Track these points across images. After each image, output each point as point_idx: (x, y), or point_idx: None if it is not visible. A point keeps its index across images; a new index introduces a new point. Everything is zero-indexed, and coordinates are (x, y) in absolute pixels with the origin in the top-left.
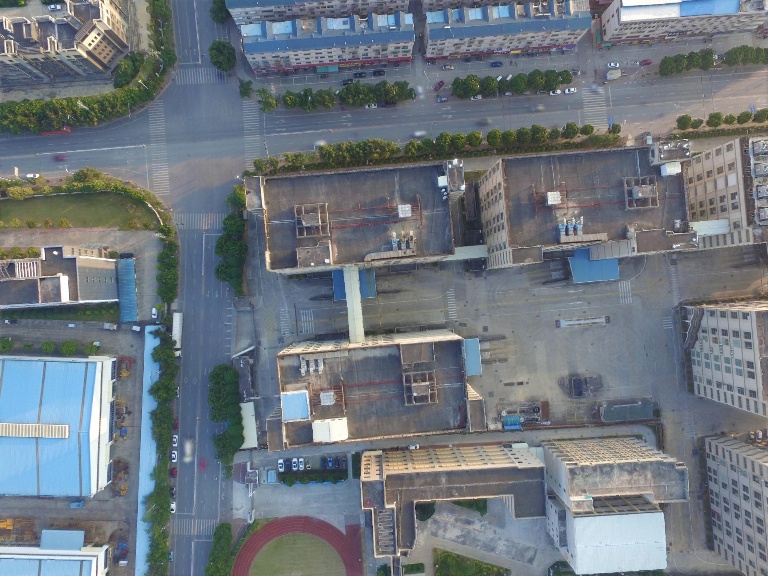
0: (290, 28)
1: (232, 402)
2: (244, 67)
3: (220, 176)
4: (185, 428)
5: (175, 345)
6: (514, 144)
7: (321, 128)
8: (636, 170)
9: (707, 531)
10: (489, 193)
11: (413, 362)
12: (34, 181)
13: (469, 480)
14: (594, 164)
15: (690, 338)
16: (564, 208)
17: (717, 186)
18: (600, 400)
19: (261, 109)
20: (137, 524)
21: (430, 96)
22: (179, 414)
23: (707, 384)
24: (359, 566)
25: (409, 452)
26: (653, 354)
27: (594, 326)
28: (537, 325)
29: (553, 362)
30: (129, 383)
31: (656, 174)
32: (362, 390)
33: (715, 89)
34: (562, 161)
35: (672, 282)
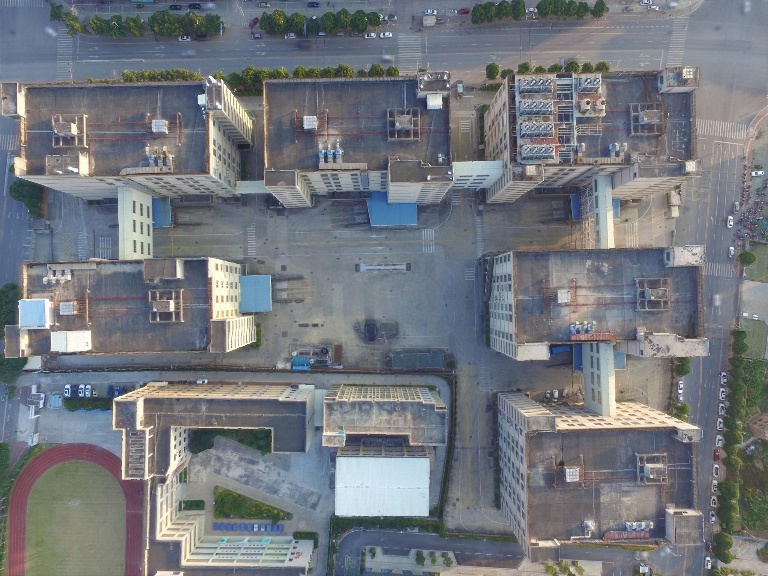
0: None
1: (14, 320)
2: None
3: None
4: None
5: None
6: None
7: (133, 57)
8: (402, 102)
9: (496, 489)
10: None
11: (155, 277)
12: None
13: (230, 410)
14: (360, 93)
15: (487, 289)
16: (325, 135)
17: (500, 129)
18: (395, 348)
19: (68, 33)
20: None
21: (245, 32)
22: None
23: (495, 335)
24: (140, 499)
25: (195, 386)
26: (453, 305)
27: (394, 272)
28: (336, 268)
29: (350, 306)
30: None
31: (422, 107)
32: (109, 304)
33: (533, 42)
34: (328, 88)
35: (477, 233)
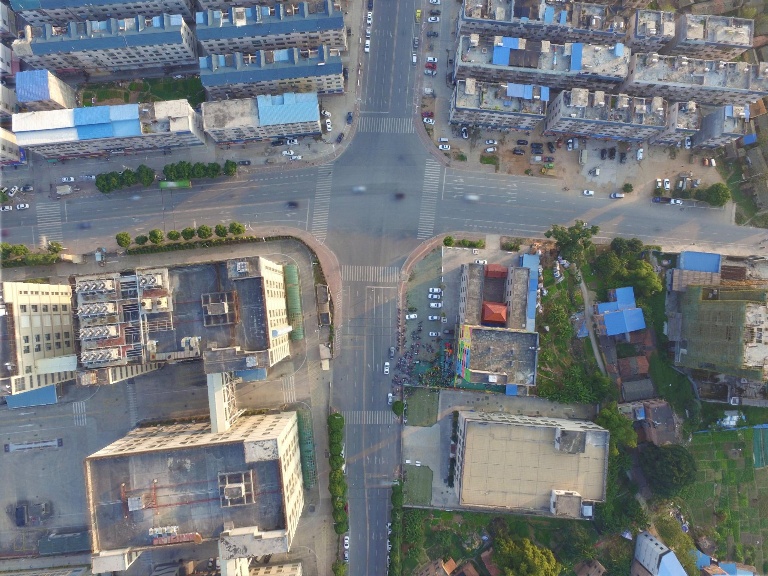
0: None
1: None
2: None
3: None
4: None
5: None
6: None
7: None
8: None
9: None
10: None
11: None
12: None
13: None
14: None
15: None
16: None
17: None
18: (50, 528)
19: None
20: None
21: None
22: None
23: None
24: None
25: None
26: None
27: (45, 450)
28: None
29: (1, 489)
30: None
31: None
32: None
33: (175, 202)
34: None
35: (129, 402)
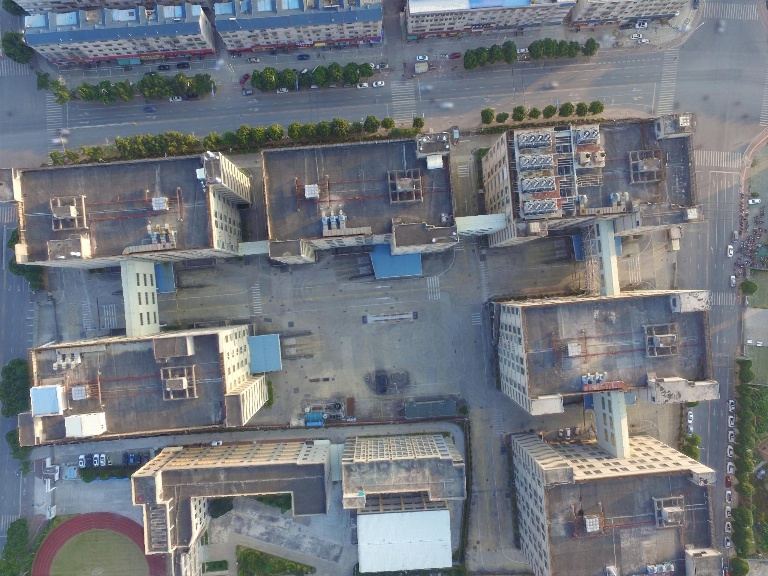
0: (75, 19)
1: (24, 397)
2: (47, 59)
3: None
4: None
5: None
6: (318, 138)
7: (125, 121)
8: (402, 163)
9: (515, 529)
10: None
11: (166, 357)
12: None
13: (248, 476)
14: (359, 157)
15: (495, 334)
16: (327, 201)
17: (500, 180)
18: (407, 397)
19: (57, 101)
20: None
21: (236, 89)
22: None
23: (506, 381)
24: (162, 563)
25: (210, 448)
26: (461, 350)
27: (401, 322)
28: (343, 321)
29: (360, 358)
30: None
31: (422, 167)
32: (121, 385)
33: (526, 83)
34: (327, 154)
35: (481, 278)
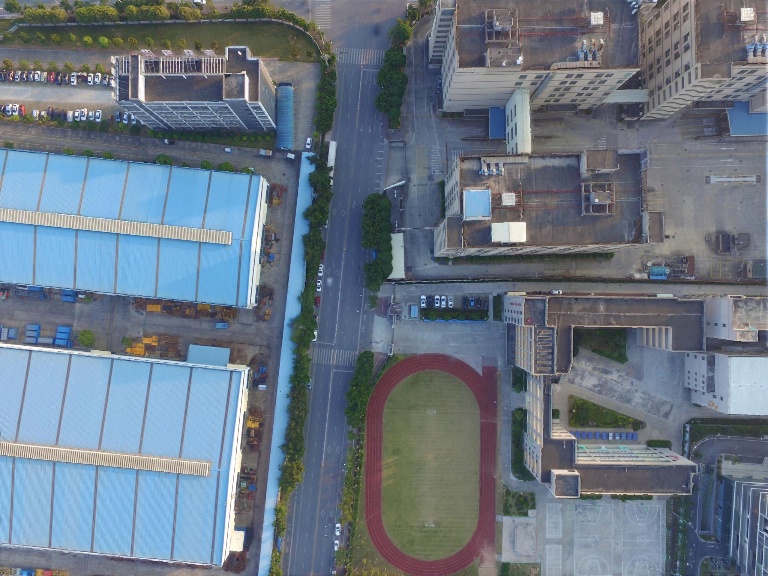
0: None
1: (386, 228)
2: None
3: (381, 13)
4: (331, 259)
5: (331, 171)
6: None
7: None
8: None
9: None
10: (662, 28)
11: (597, 168)
12: (201, 6)
13: (627, 309)
14: None
15: None
16: (753, 29)
17: None
18: (746, 259)
19: None
20: (282, 346)
21: None
22: (326, 245)
23: None
24: (493, 408)
25: None
26: None
27: (744, 184)
28: (687, 180)
29: (701, 218)
30: (279, 211)
31: None
32: (540, 198)
33: None
34: None
35: None
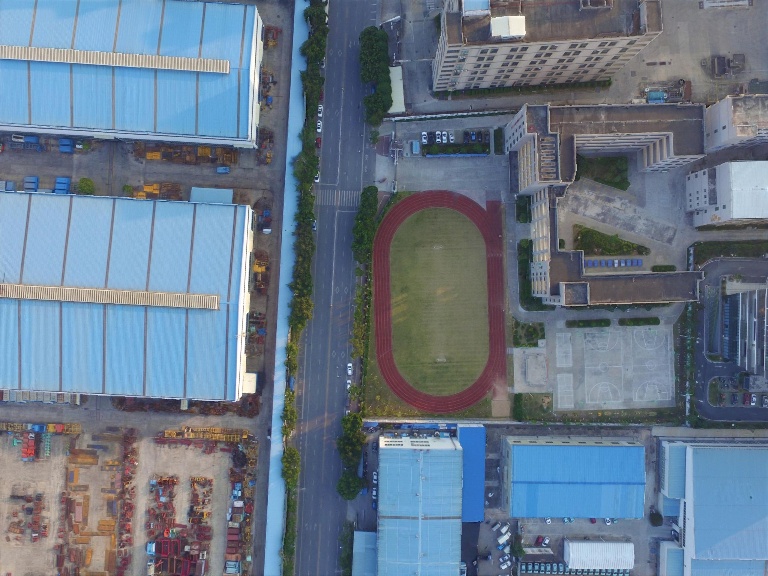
0: None
1: (384, 59)
2: None
3: None
4: (330, 99)
5: (326, 5)
6: None
7: None
8: None
9: None
10: None
11: None
12: None
13: (628, 117)
14: None
15: None
16: None
17: None
18: (742, 82)
19: None
20: (285, 184)
21: None
22: (324, 85)
23: None
24: (499, 242)
25: None
26: None
27: (737, 8)
28: (680, 6)
29: (696, 43)
30: (275, 53)
31: None
32: None
33: None
34: None
35: None
